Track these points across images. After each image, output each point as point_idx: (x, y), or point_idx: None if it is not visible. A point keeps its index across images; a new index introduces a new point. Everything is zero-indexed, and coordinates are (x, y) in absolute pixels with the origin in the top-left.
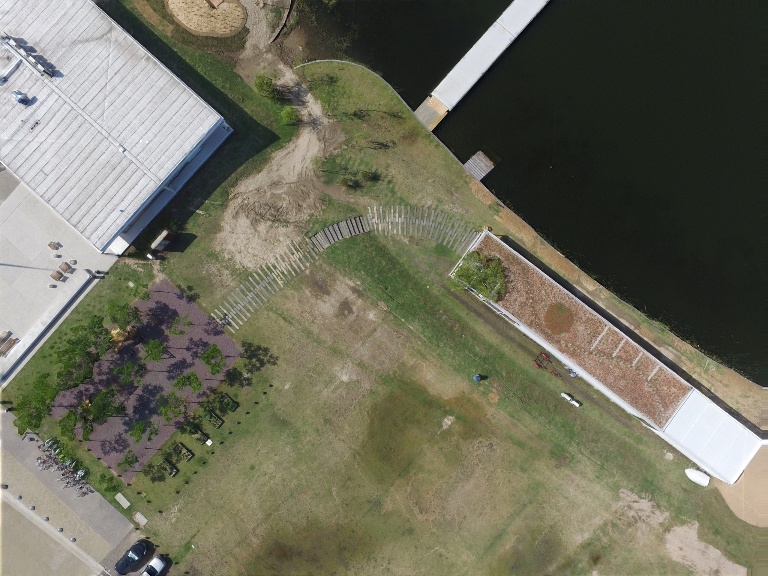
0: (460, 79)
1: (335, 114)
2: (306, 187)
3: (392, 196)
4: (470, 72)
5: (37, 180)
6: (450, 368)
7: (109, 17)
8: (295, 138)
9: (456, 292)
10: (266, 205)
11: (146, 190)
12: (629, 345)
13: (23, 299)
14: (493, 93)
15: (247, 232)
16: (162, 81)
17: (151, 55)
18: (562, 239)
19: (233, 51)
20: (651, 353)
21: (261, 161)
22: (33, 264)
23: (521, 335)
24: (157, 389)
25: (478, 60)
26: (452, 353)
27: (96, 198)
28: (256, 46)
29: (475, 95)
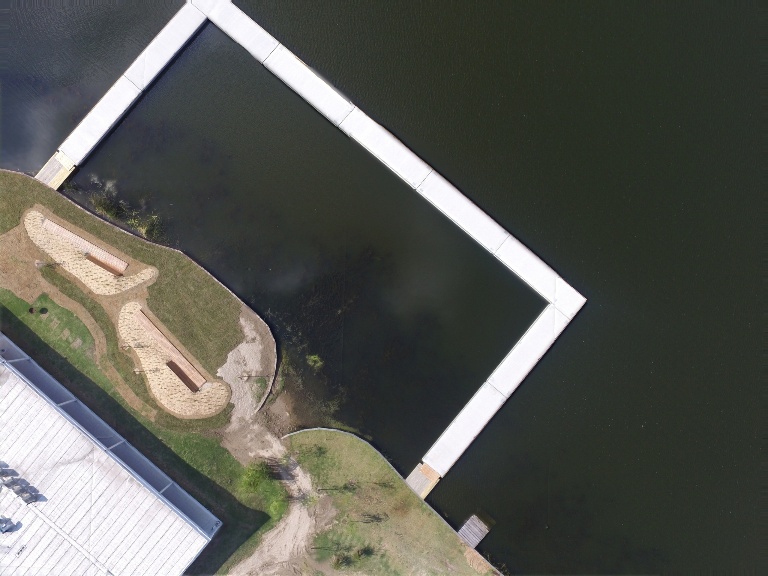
0: (451, 444)
1: (325, 488)
2: (298, 565)
3: (386, 570)
4: (462, 436)
5: None
6: None
7: (90, 437)
8: (285, 515)
9: None
10: None
11: None
12: None
13: None
14: (486, 451)
15: None
16: (147, 503)
17: (135, 477)
18: None
19: (219, 427)
20: None
21: (252, 544)
22: None
23: None
24: None
25: (469, 423)
26: None
27: None
28: (242, 418)
29: (467, 456)
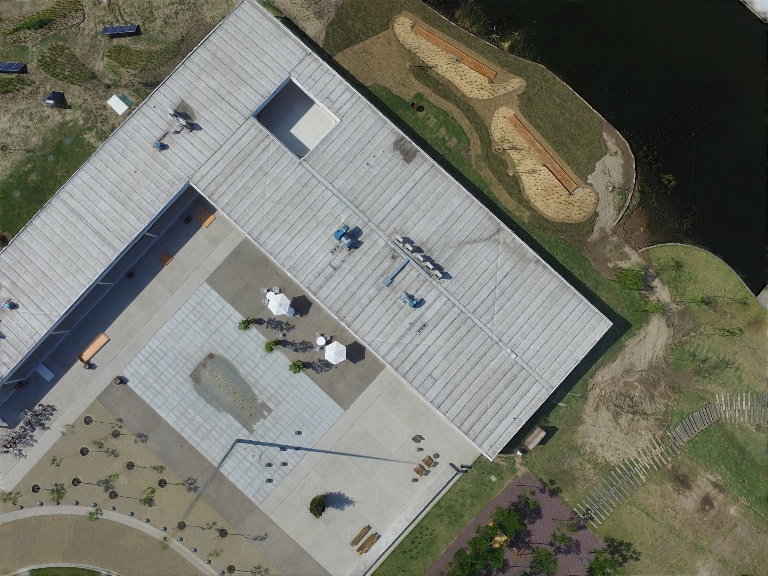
0: None
1: (683, 300)
2: (656, 375)
3: (739, 384)
4: None
5: (426, 385)
6: None
7: (496, 217)
8: (645, 325)
9: None
10: (621, 395)
11: (538, 397)
12: None
13: (383, 492)
14: None
15: (609, 425)
16: (552, 285)
17: (541, 259)
18: None
19: (583, 235)
20: None
21: (616, 350)
22: (394, 457)
23: None
24: None
25: None
26: None
27: (487, 405)
28: (603, 229)
29: None
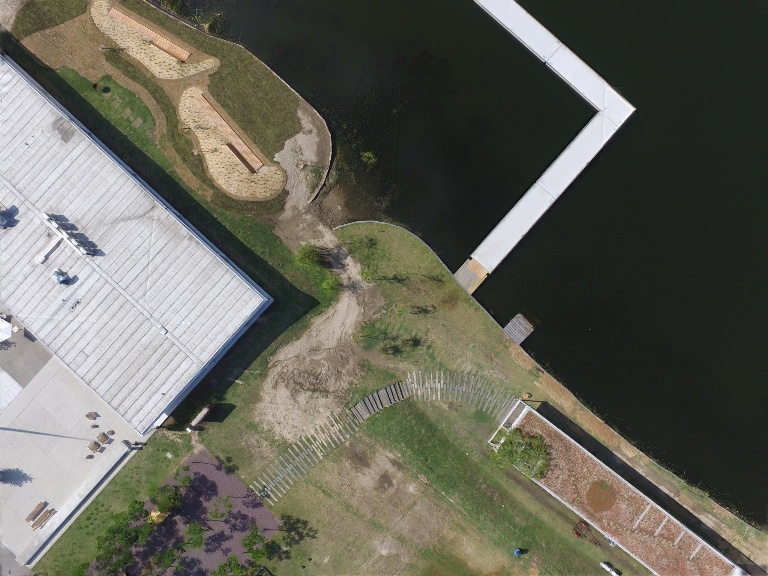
0: (500, 241)
1: (375, 278)
2: (345, 352)
3: (431, 361)
4: (510, 234)
5: (78, 361)
6: (490, 542)
7: (151, 195)
8: (334, 302)
9: None
10: (305, 372)
11: (188, 373)
12: (671, 524)
13: (60, 469)
14: (532, 253)
15: (287, 403)
16: (205, 261)
17: (194, 235)
18: (601, 404)
19: (272, 213)
20: (690, 521)
21: (300, 327)
22: (70, 434)
23: (560, 503)
24: (195, 562)
25: (518, 222)
26: (492, 527)
27: (137, 380)
28: (295, 207)
29: (515, 256)
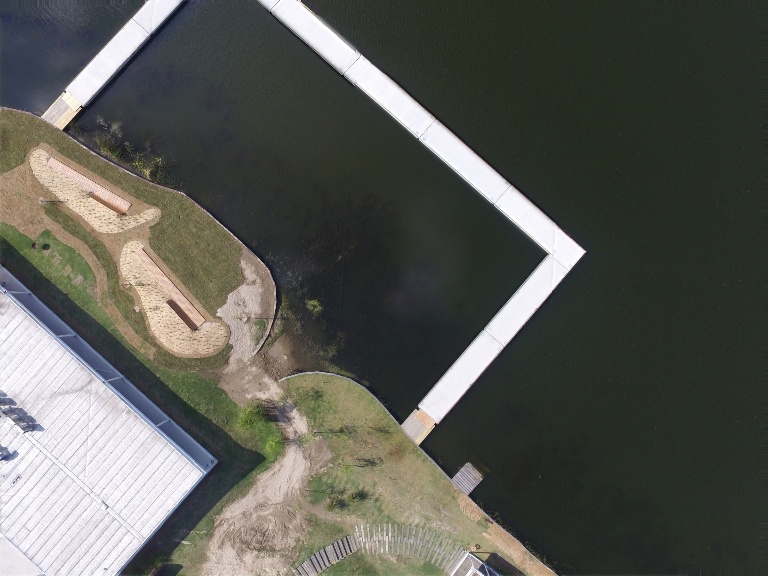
0: (448, 391)
1: (321, 431)
2: (292, 507)
3: (379, 514)
4: (458, 383)
5: (20, 536)
6: None
7: (89, 368)
8: (281, 457)
9: None
10: (252, 529)
11: (129, 548)
12: None
13: None
14: (482, 400)
15: (233, 563)
16: (144, 435)
17: (132, 409)
18: (551, 553)
19: (217, 367)
20: None
21: (246, 485)
22: None
23: None
24: None
25: (466, 371)
26: None
27: (79, 555)
28: (240, 360)
29: (463, 404)
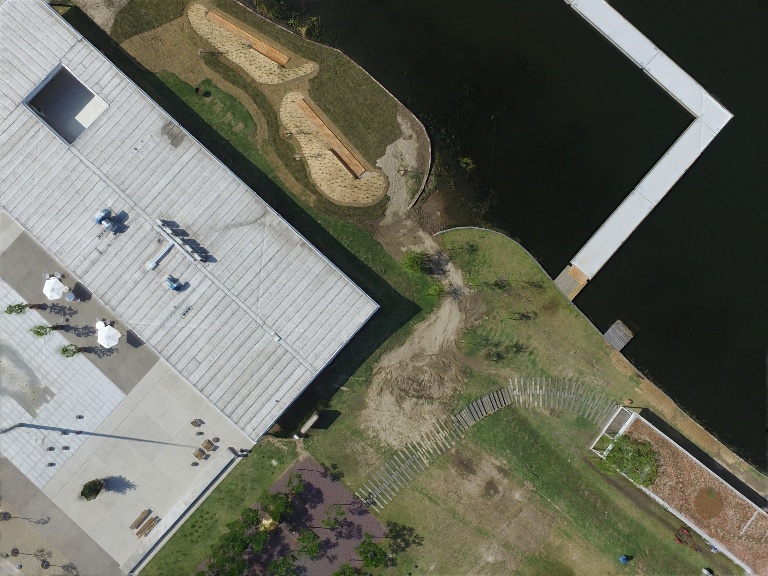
0: (600, 248)
1: (476, 284)
2: (447, 359)
3: (533, 368)
4: (610, 241)
5: (190, 368)
6: (596, 549)
7: (263, 201)
8: (436, 309)
9: (597, 466)
10: (409, 379)
11: (302, 380)
12: None
13: (164, 476)
14: (631, 260)
15: (392, 409)
16: (318, 268)
17: (307, 241)
18: (701, 410)
19: (373, 219)
20: None
21: (404, 334)
22: (174, 441)
23: (661, 509)
24: (300, 569)
25: (618, 229)
26: (598, 533)
27: (250, 387)
28: (396, 213)
29: (613, 263)
